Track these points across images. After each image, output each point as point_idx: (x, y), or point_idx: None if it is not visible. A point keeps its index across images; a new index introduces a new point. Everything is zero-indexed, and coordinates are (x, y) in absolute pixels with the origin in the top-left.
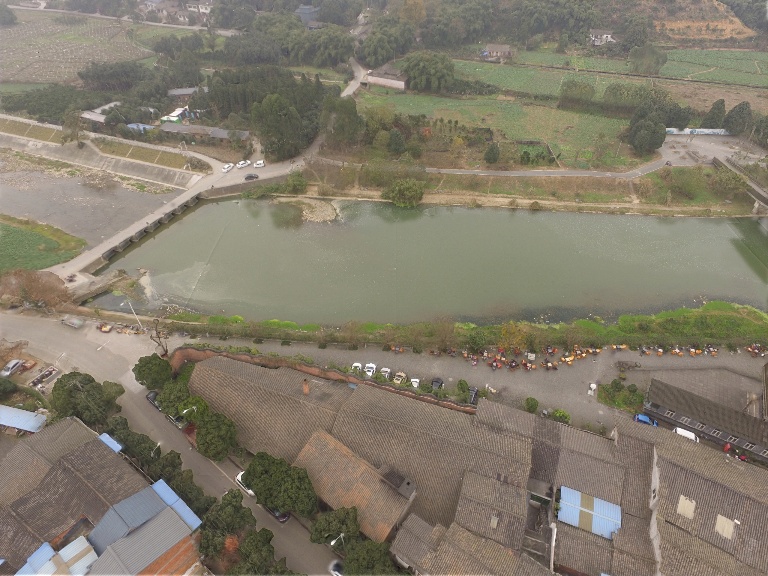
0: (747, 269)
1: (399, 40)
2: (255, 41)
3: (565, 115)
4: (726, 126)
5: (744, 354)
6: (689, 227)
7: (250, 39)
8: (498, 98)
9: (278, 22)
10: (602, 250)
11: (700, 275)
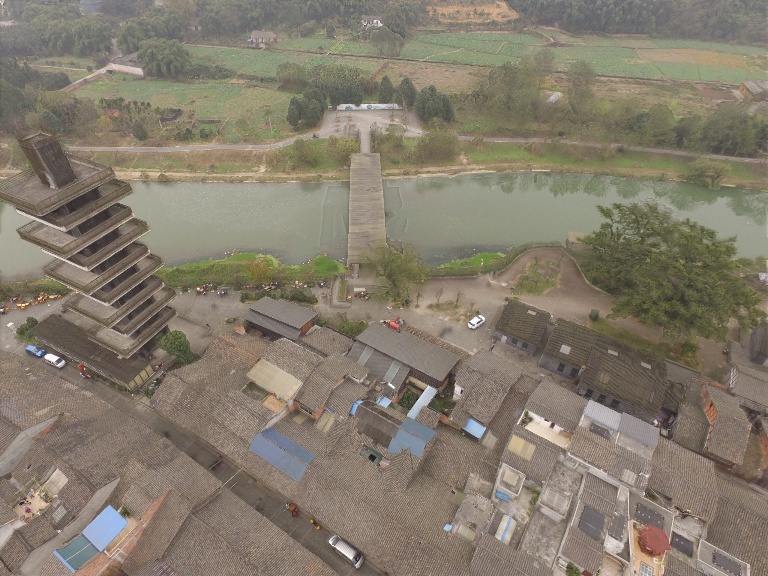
0: (302, 225)
1: (158, 28)
2: (14, 32)
3: (275, 95)
4: (397, 101)
5: (192, 293)
6: (290, 191)
7: (11, 30)
8: (229, 82)
9: (43, 13)
10: (186, 214)
11: (255, 232)
